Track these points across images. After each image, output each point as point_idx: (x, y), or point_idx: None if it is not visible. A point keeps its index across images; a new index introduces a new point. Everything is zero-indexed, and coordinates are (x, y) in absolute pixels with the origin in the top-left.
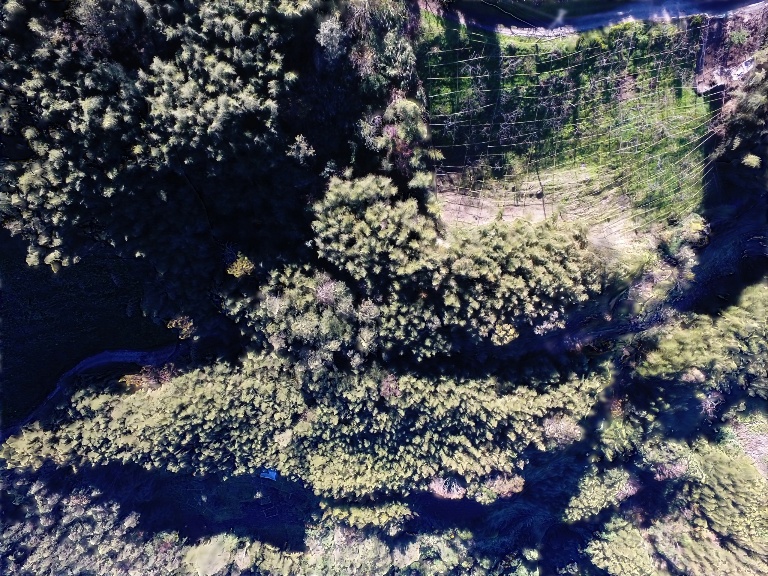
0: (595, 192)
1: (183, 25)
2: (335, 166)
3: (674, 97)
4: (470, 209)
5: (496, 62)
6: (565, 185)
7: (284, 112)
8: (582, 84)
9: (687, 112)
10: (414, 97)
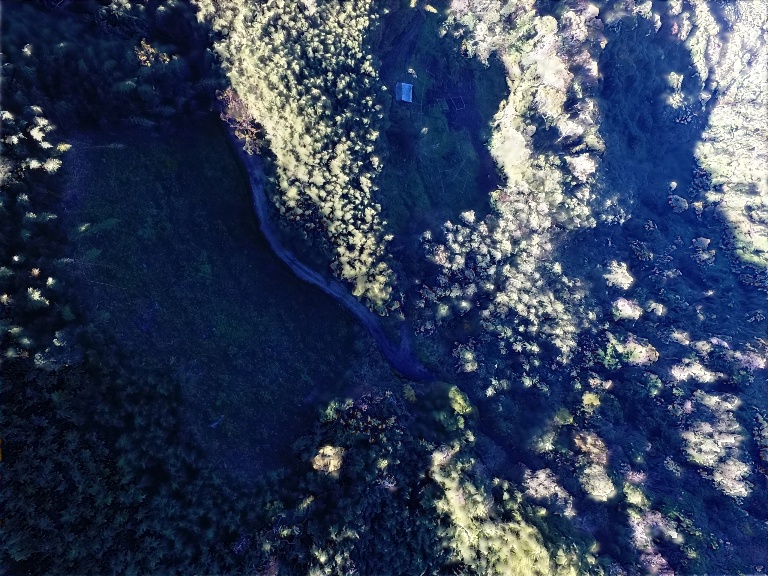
0: None
1: None
2: None
3: None
4: None
5: None
6: None
7: None
8: None
9: None
10: None
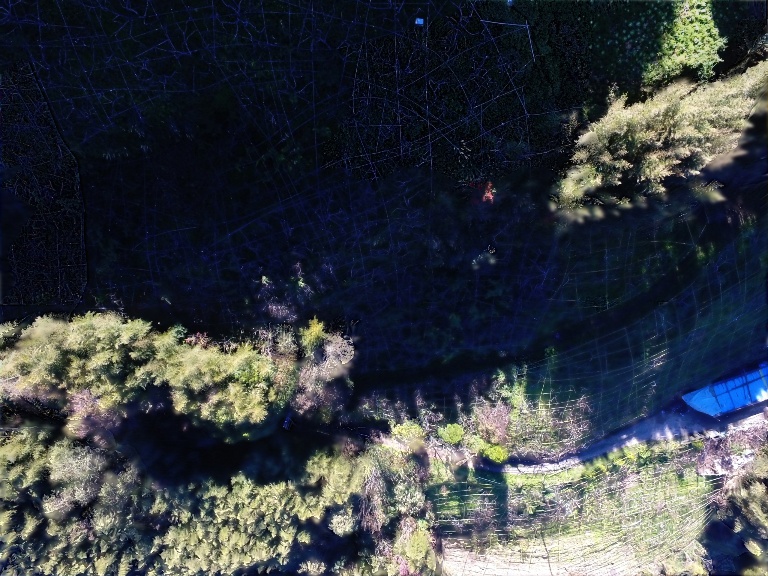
0: (599, 550)
1: (198, 518)
2: (345, 561)
3: (676, 478)
4: (477, 562)
5: (503, 498)
6: (570, 549)
7: (296, 550)
8: (587, 488)
9: (689, 488)
10: (423, 518)
